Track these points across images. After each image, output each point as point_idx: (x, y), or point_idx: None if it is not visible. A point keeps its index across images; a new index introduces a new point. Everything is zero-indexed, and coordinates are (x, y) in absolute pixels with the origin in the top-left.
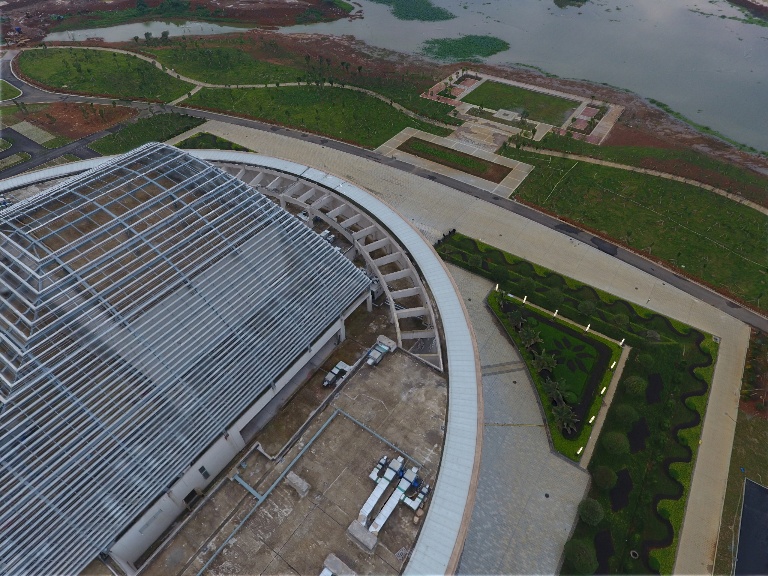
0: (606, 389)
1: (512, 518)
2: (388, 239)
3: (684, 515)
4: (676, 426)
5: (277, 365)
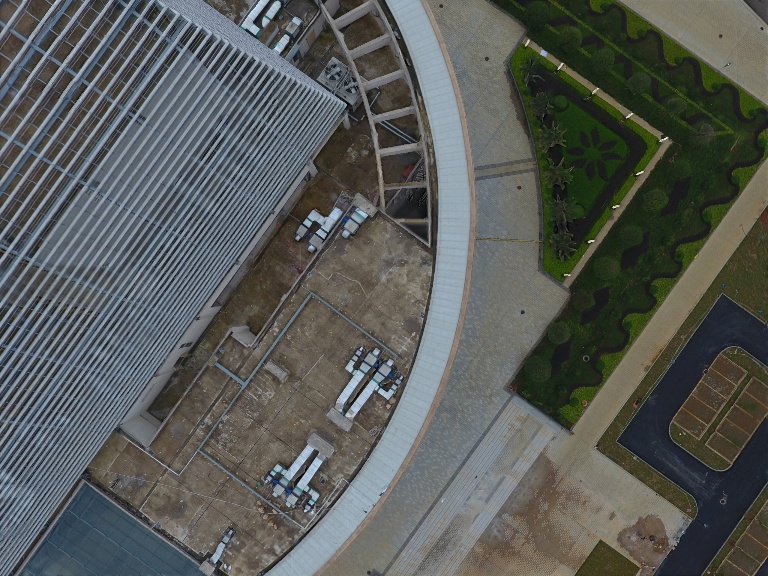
0: (620, 200)
1: (485, 331)
2: (372, 3)
3: (645, 326)
4: (679, 240)
5: (235, 247)
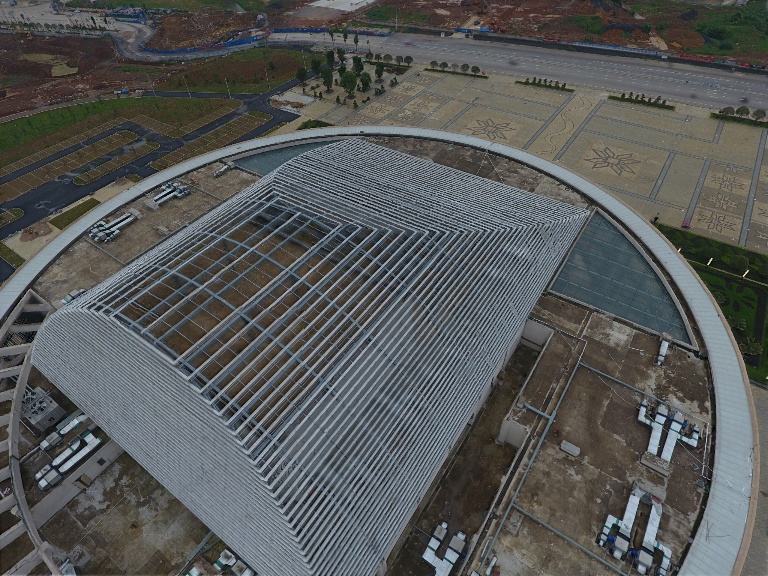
0: None
1: None
2: None
3: None
4: None
5: None
